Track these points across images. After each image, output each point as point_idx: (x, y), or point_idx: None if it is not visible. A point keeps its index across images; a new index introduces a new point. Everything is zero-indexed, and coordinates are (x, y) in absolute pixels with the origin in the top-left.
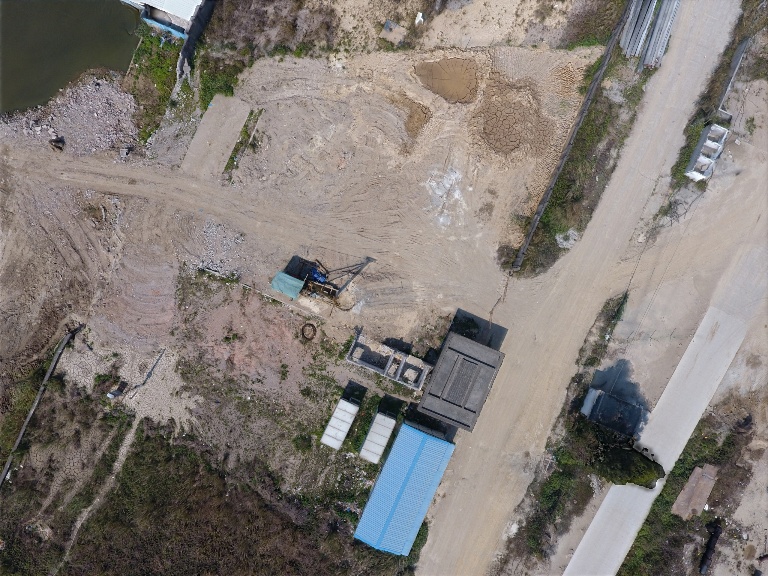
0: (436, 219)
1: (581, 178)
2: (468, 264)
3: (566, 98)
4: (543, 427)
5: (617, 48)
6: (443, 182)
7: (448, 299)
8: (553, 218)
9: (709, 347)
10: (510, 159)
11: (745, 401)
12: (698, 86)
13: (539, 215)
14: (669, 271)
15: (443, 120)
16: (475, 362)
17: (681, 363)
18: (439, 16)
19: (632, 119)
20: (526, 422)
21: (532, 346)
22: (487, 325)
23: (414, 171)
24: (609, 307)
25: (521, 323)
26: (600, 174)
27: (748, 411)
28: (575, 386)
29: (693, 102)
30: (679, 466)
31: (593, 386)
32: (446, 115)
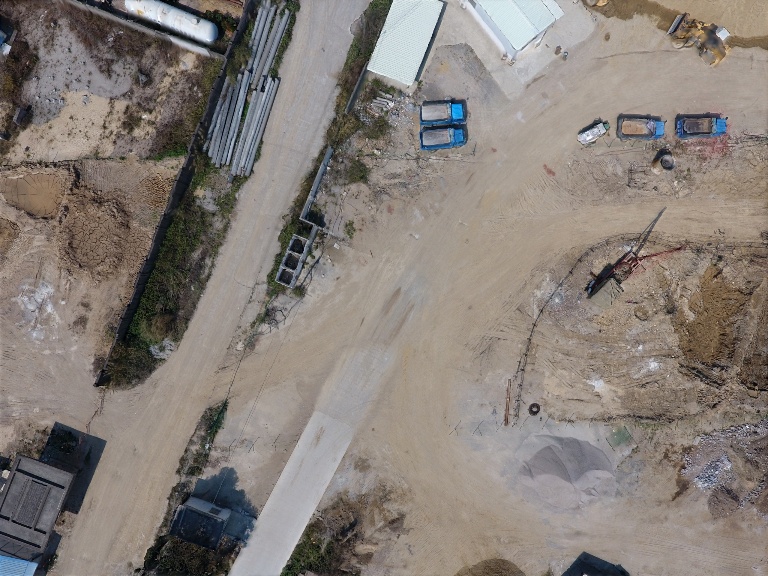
0: (29, 334)
1: (175, 288)
2: (63, 377)
3: (158, 208)
4: (145, 537)
5: (201, 158)
6: (35, 297)
7: (45, 413)
8: (142, 331)
9: (314, 452)
10: (96, 273)
11: (354, 505)
12: (292, 192)
13: (115, 332)
14: (270, 378)
15: (32, 235)
16: (44, 483)
17: (286, 469)
18: (25, 131)
19: (225, 227)
20: (127, 533)
21: (132, 457)
22: (84, 438)
23: (6, 287)
24: (206, 417)
25: (120, 434)
26: (195, 283)
27: (355, 515)
28: (177, 495)
29: (288, 208)
30: (285, 572)
31: (196, 495)
32: (35, 230)
